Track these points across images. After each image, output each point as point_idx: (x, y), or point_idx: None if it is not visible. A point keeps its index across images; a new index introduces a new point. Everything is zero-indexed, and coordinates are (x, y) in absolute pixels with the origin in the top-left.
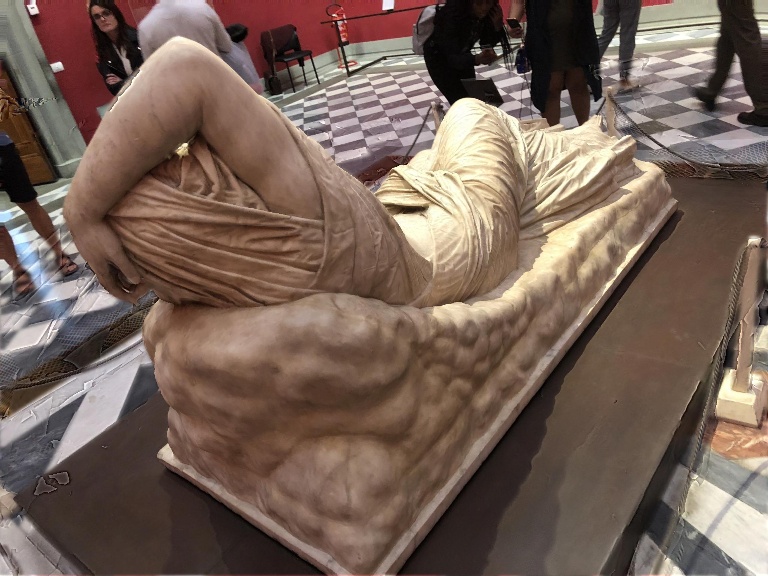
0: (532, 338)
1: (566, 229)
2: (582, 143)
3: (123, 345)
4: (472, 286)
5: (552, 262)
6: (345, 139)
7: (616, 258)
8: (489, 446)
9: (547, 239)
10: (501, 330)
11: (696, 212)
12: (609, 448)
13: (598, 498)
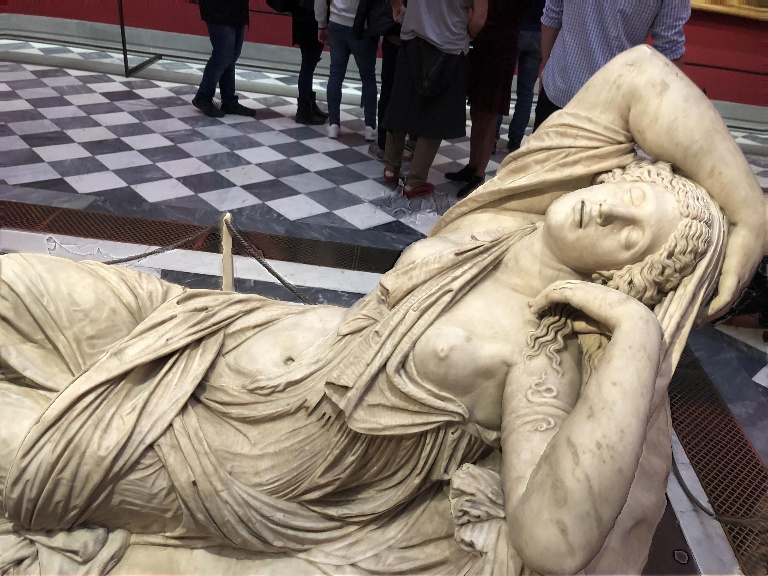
0: None
1: None
2: None
3: None
4: None
5: None
6: None
7: None
8: None
9: None
10: None
11: None
12: None
13: None
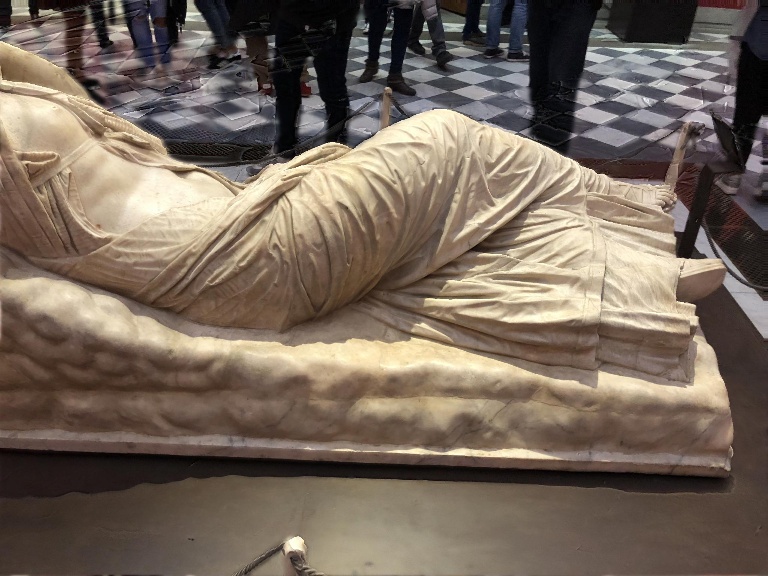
0: (211, 405)
1: (435, 350)
2: (596, 274)
3: (182, 160)
4: (169, 301)
5: (323, 360)
6: (702, 120)
7: (473, 436)
8: (70, 445)
9: (401, 341)
10: (125, 359)
11: (742, 507)
12: (104, 558)
13: (14, 572)
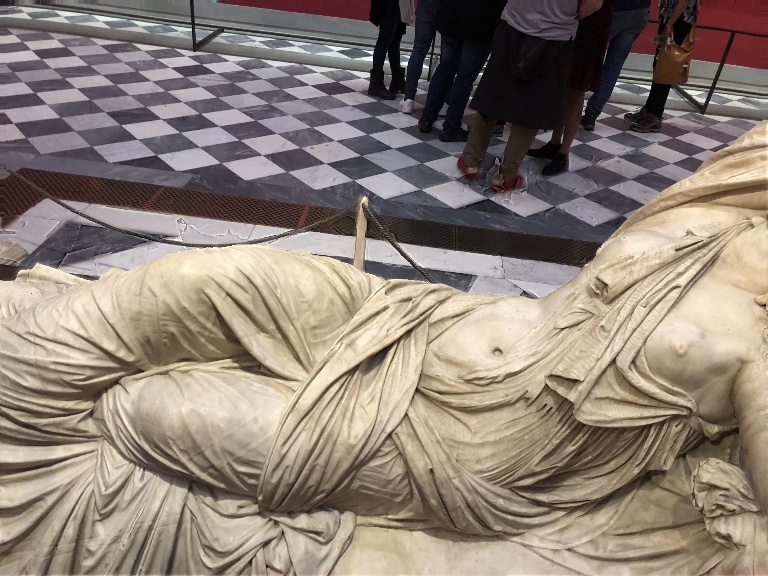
0: None
1: None
2: None
3: None
4: None
5: None
6: None
7: None
8: None
9: None
10: None
11: None
12: None
13: None
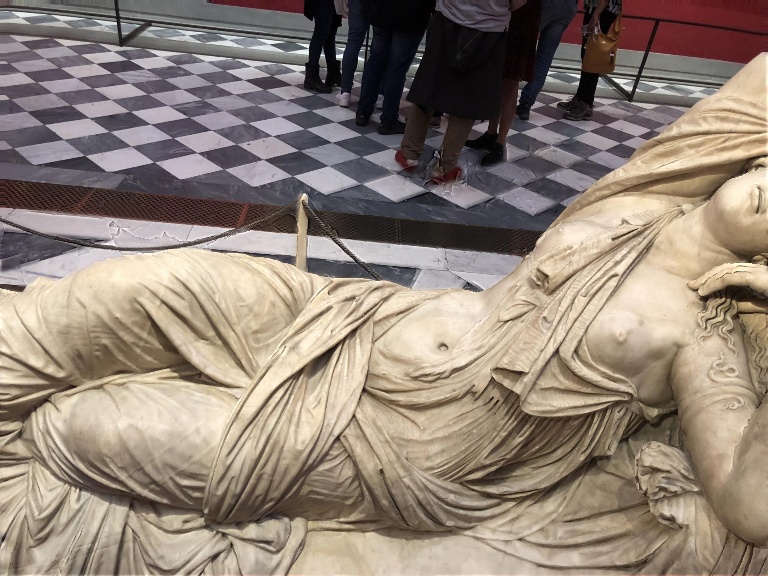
0: None
1: None
2: None
3: None
4: None
5: None
6: None
7: None
8: None
9: None
10: None
11: None
12: None
13: None
